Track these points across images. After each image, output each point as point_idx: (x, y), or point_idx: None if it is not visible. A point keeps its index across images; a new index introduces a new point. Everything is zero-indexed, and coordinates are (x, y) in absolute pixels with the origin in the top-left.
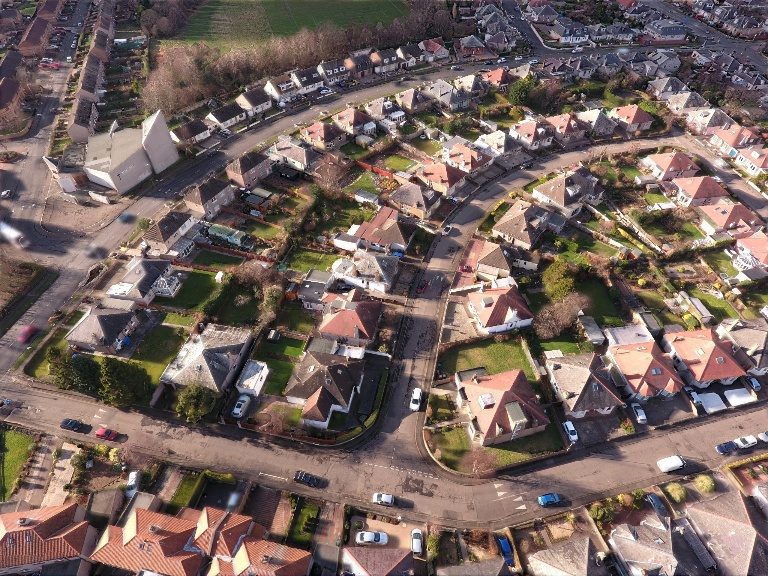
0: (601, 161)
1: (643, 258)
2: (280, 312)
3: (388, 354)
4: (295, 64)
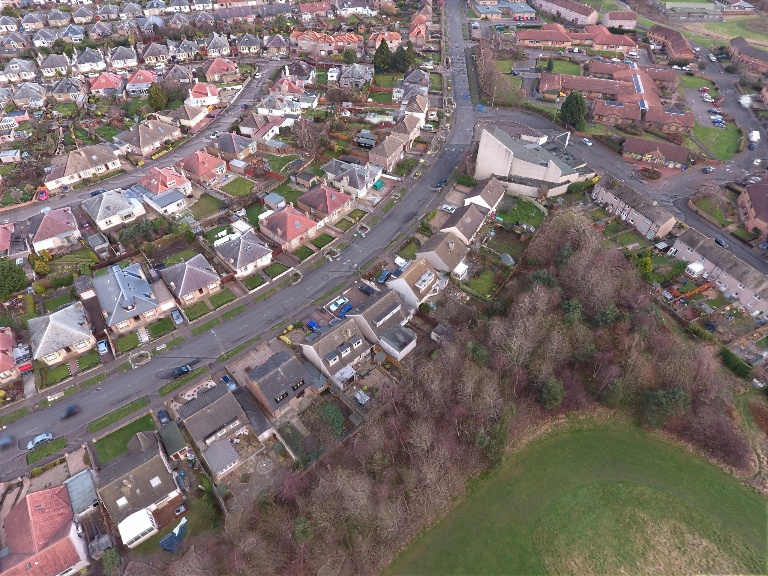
0: None
1: None
2: None
3: None
4: None
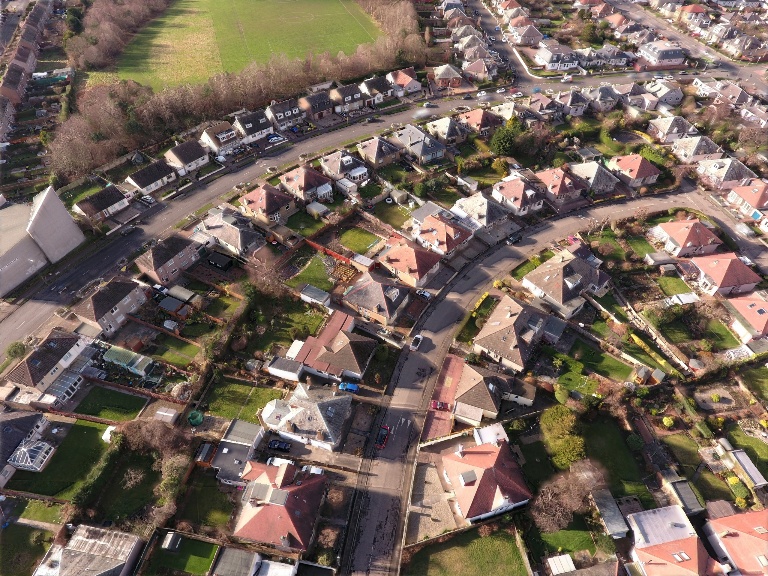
0: (603, 230)
1: (666, 382)
2: (187, 492)
3: (331, 567)
4: (242, 103)
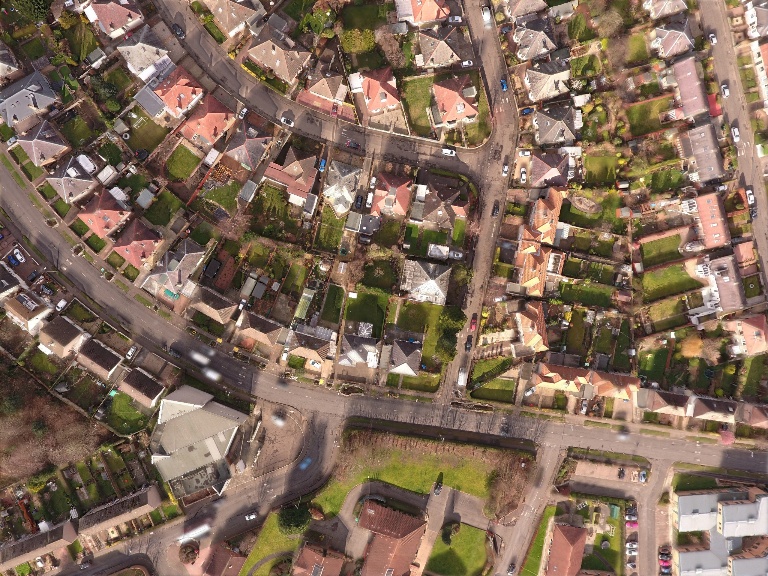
0: None
1: None
2: None
3: None
4: None
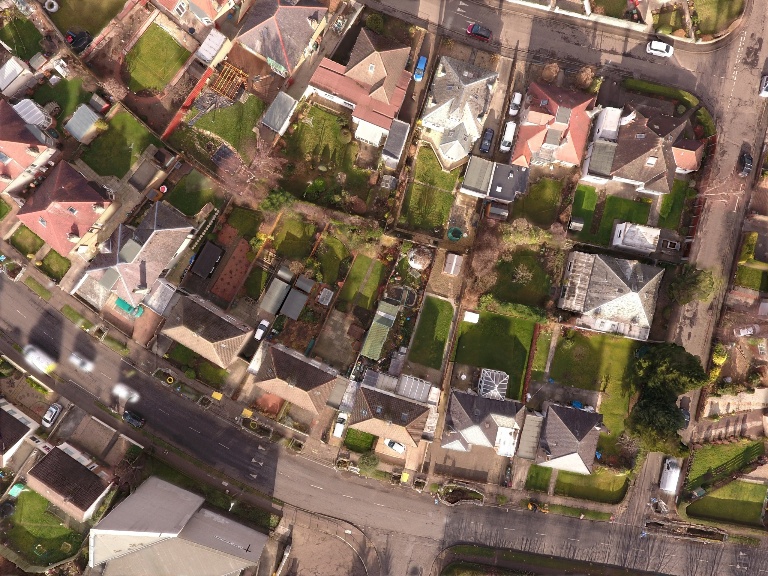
0: None
1: None
2: None
3: None
4: None
